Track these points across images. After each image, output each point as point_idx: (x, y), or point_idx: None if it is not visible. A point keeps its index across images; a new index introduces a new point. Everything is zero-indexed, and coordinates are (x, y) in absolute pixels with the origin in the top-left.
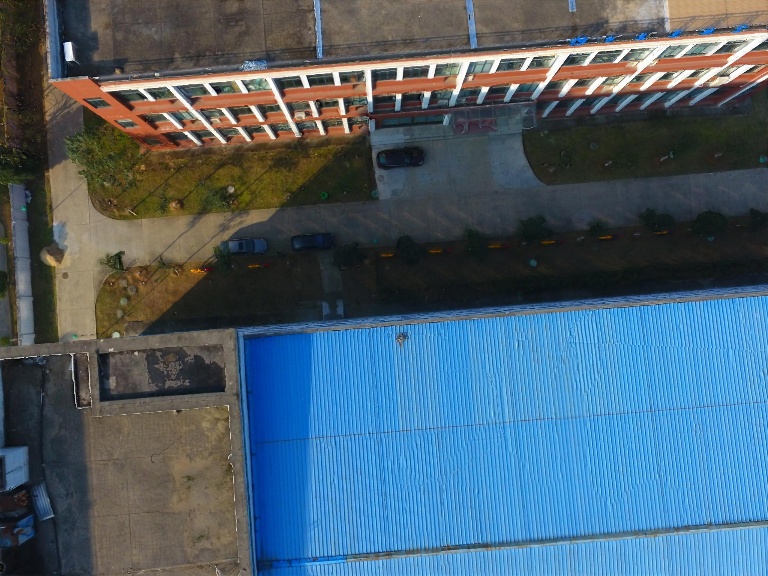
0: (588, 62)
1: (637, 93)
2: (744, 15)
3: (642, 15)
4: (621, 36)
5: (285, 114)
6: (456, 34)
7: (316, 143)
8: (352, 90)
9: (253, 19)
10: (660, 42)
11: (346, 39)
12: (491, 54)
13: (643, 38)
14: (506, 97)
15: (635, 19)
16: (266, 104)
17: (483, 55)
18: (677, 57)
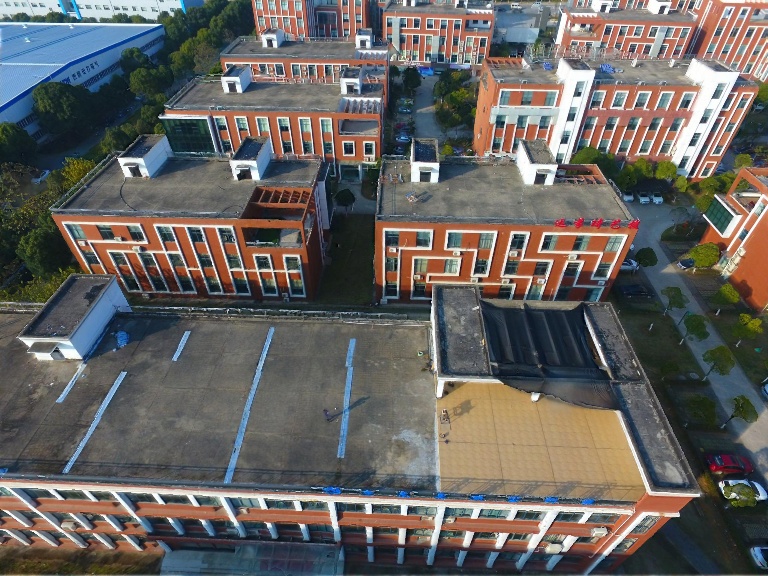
0: (370, 511)
1: (463, 549)
2: (522, 483)
3: (412, 470)
4: (387, 490)
5: (51, 523)
6: (214, 466)
7: (101, 558)
8: (114, 507)
9: (29, 427)
10: (430, 502)
11: (103, 457)
12: (243, 492)
13: (407, 495)
14: (303, 535)
15: (404, 473)
16: (27, 510)
17: (234, 492)
18: (474, 517)
